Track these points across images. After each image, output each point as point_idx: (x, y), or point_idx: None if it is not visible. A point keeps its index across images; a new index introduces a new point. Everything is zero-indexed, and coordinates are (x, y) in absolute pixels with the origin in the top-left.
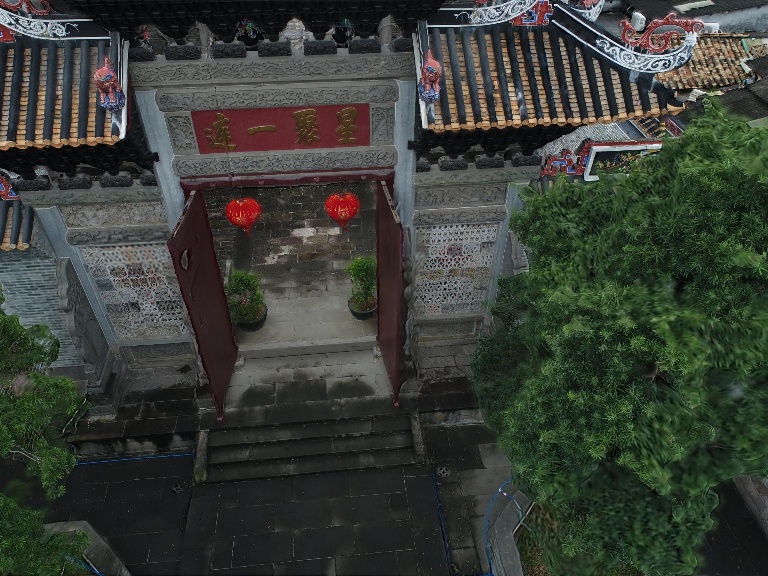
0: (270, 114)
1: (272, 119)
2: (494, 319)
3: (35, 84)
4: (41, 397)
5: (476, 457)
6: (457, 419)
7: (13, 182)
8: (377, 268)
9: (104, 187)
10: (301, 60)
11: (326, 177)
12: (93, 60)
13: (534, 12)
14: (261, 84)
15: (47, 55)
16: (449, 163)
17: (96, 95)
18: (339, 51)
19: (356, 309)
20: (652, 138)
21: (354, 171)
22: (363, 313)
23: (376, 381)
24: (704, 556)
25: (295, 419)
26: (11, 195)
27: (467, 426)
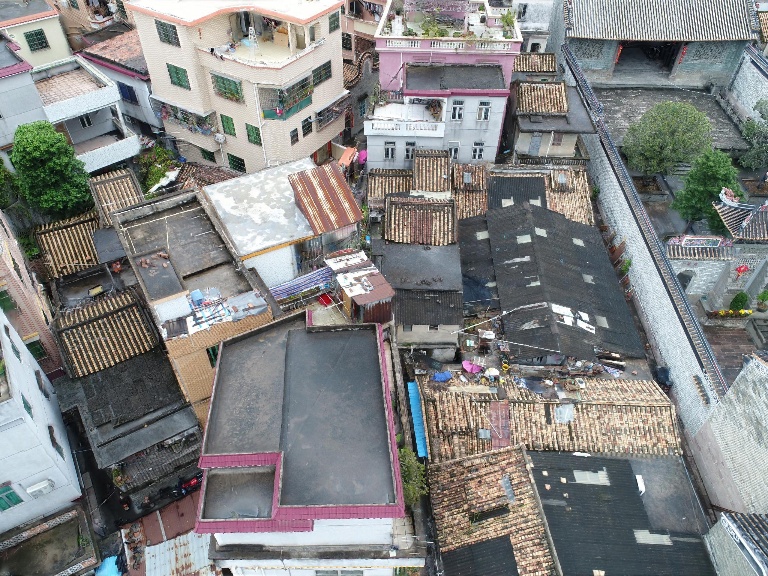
0: None
1: None
2: None
3: None
4: None
5: None
6: None
7: None
8: None
9: None
10: None
11: None
12: None
13: None
14: None
15: None
16: None
17: None
18: None
19: (764, 303)
20: (702, 236)
21: None
22: None
23: None
24: None
25: None
26: None
27: None
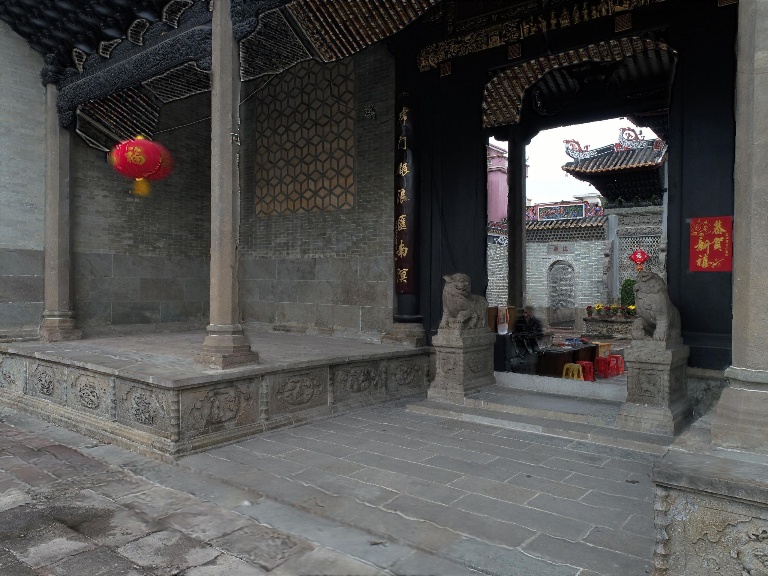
0: None
1: None
2: None
3: None
4: None
5: None
6: None
7: None
8: None
9: None
10: None
11: None
12: None
13: None
14: None
15: None
16: None
17: None
18: None
19: None
20: None
21: None
22: None
23: None
24: None
25: None
26: None
27: None
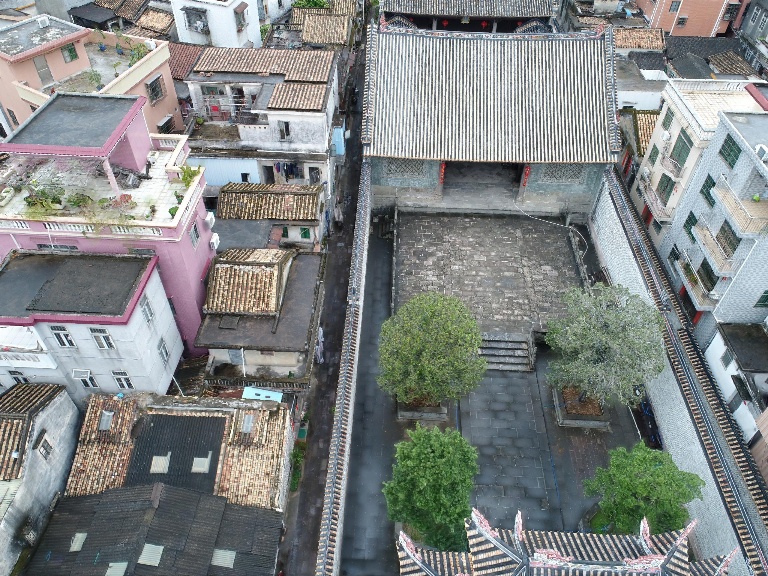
0: None
1: None
2: None
3: None
4: None
5: None
6: None
7: None
8: None
9: None
10: None
11: None
12: None
13: None
14: None
15: None
16: None
17: None
18: None
19: None
20: None
21: None
22: None
23: None
24: (371, 525)
25: None
26: None
27: None
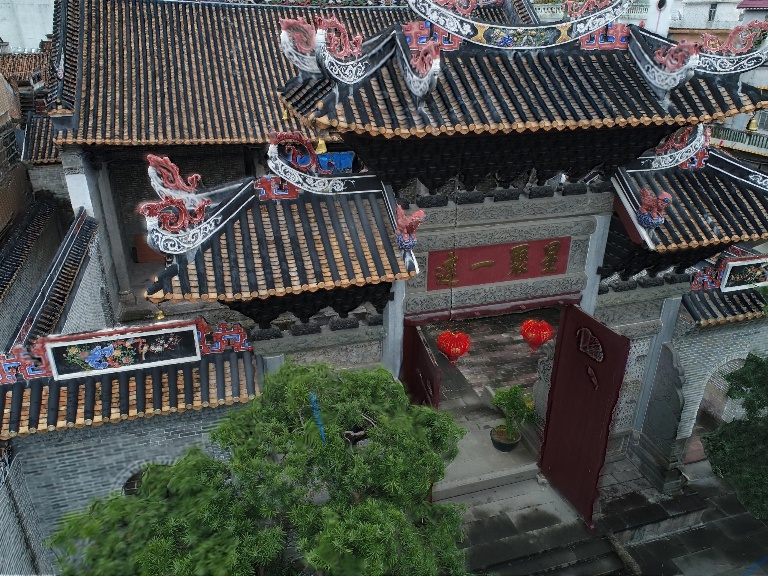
0: (492, 251)
1: (493, 255)
2: (644, 431)
3: (326, 232)
4: (449, 523)
5: (677, 572)
6: (641, 536)
7: (248, 333)
8: (551, 390)
9: (334, 330)
10: (529, 202)
11: (529, 304)
12: (366, 210)
13: (695, 158)
14: (491, 225)
15: (326, 208)
16: (624, 284)
17: (381, 238)
18: (554, 194)
19: (503, 440)
20: None
21: (550, 297)
22: (512, 443)
23: (556, 508)
24: None
25: (499, 559)
26: (244, 346)
27: (650, 543)
